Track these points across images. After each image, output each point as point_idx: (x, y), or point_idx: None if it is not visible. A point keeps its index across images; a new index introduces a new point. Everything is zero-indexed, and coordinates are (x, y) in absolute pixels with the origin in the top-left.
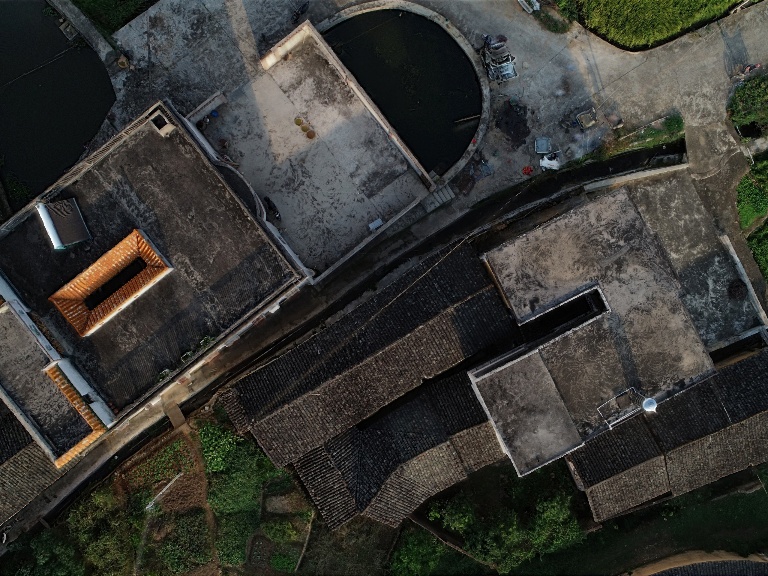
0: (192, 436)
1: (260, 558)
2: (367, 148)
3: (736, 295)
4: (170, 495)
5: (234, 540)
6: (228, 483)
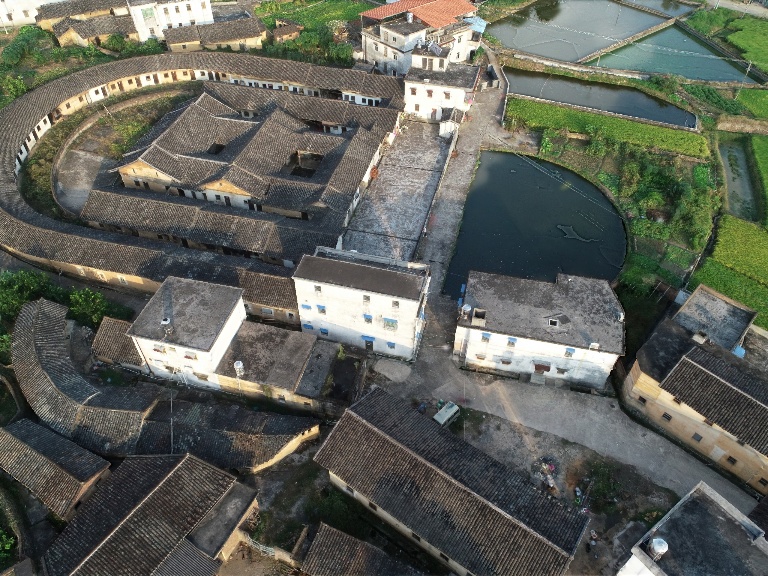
0: None
1: None
2: None
3: None
4: None
5: None
6: None
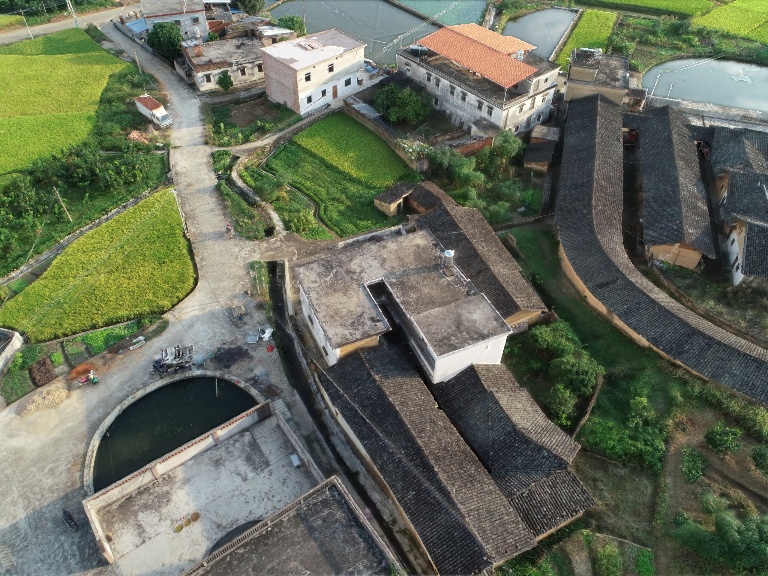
0: None
1: None
2: (222, 465)
3: (379, 240)
4: None
5: None
6: None
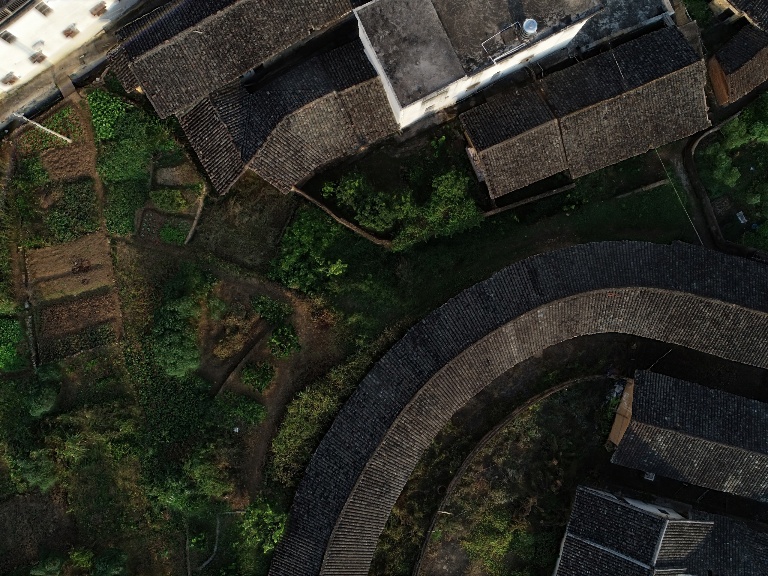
0: (82, 105)
1: (150, 231)
2: None
3: None
4: (58, 162)
5: (122, 208)
6: (117, 150)
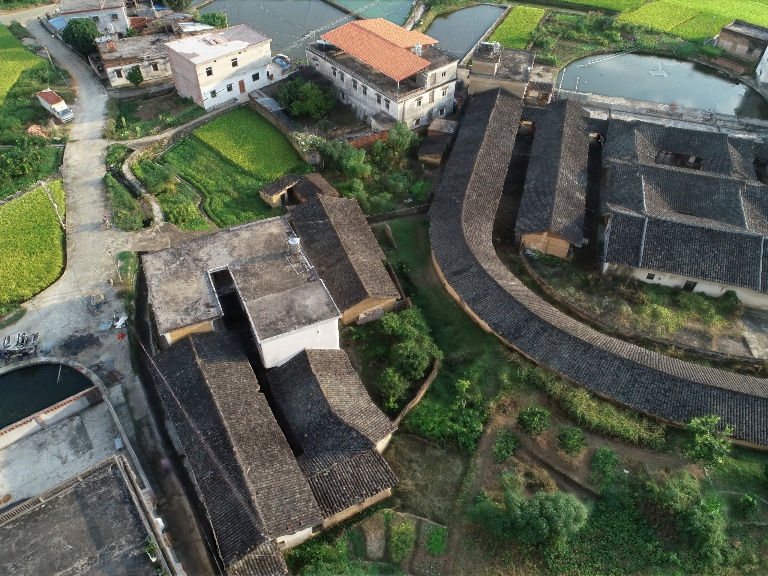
0: None
1: (433, 567)
2: (45, 448)
3: None
4: None
5: None
6: None
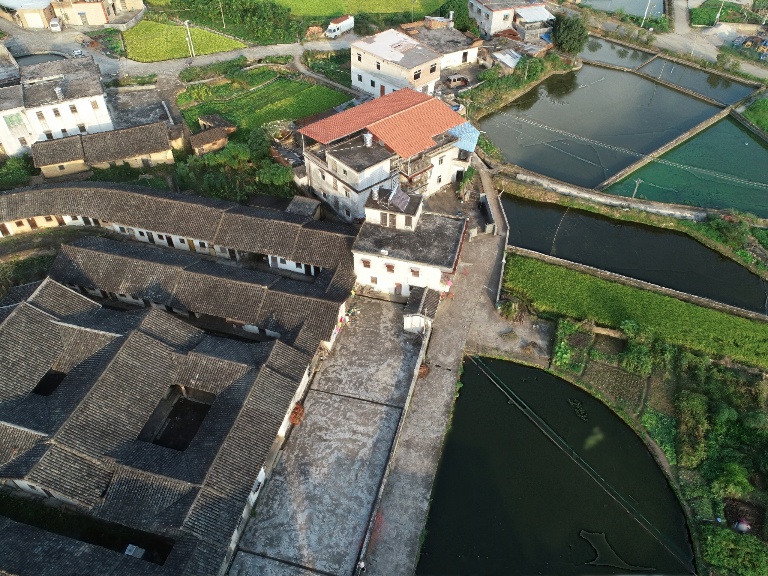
0: None
1: None
2: (8, 76)
3: (161, 116)
4: None
5: None
6: None
